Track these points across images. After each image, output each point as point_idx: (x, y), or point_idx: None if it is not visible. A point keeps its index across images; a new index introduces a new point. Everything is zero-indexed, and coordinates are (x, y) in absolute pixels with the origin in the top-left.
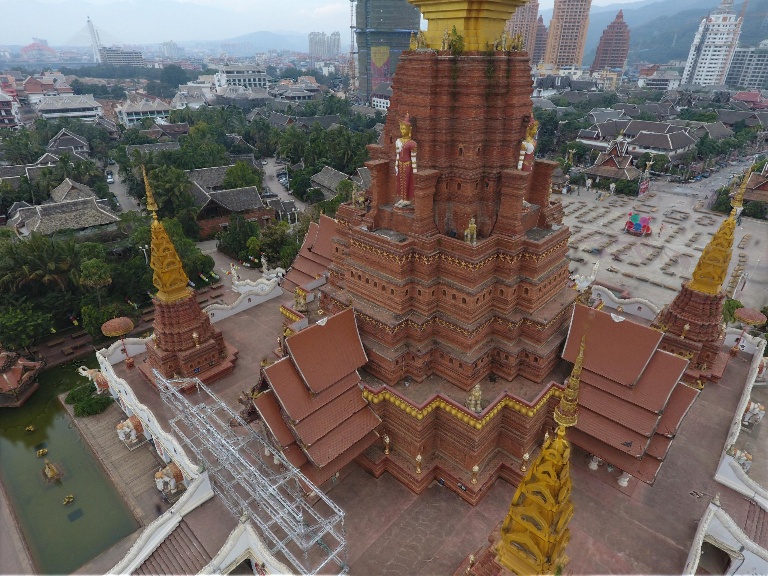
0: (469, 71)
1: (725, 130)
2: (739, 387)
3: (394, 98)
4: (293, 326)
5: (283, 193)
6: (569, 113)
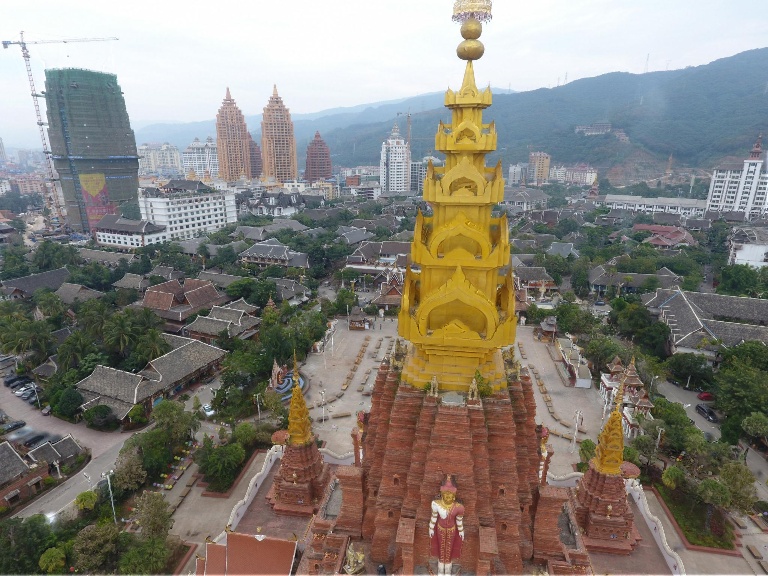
0: (502, 414)
1: None
2: (652, 540)
3: (396, 438)
4: None
5: (32, 415)
6: (323, 235)
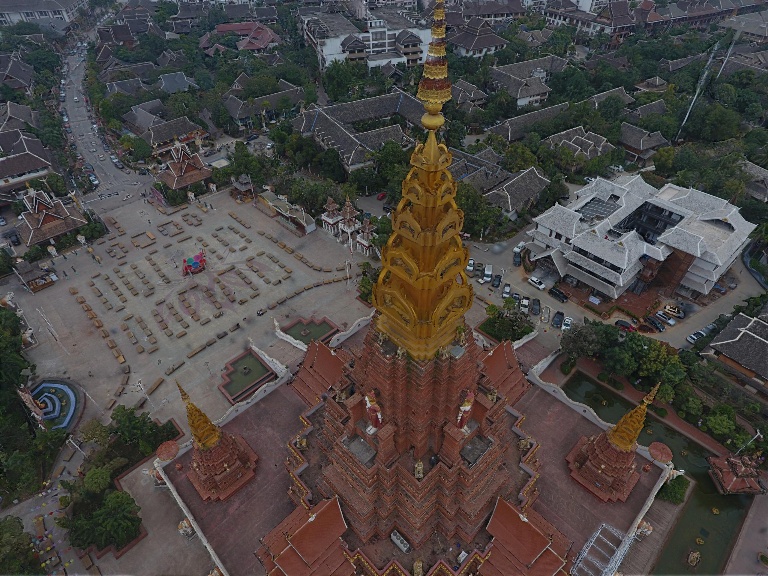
0: None
1: (23, 109)
2: None
3: (426, 393)
4: (453, 571)
5: None
6: None
